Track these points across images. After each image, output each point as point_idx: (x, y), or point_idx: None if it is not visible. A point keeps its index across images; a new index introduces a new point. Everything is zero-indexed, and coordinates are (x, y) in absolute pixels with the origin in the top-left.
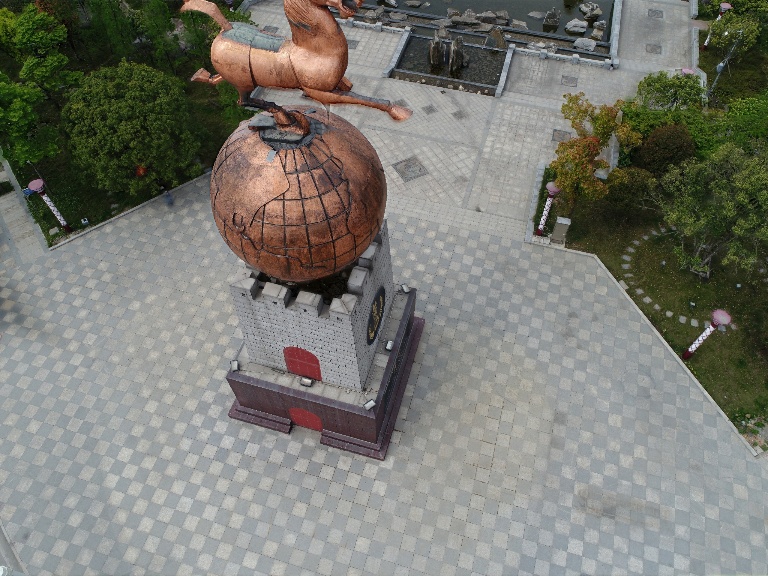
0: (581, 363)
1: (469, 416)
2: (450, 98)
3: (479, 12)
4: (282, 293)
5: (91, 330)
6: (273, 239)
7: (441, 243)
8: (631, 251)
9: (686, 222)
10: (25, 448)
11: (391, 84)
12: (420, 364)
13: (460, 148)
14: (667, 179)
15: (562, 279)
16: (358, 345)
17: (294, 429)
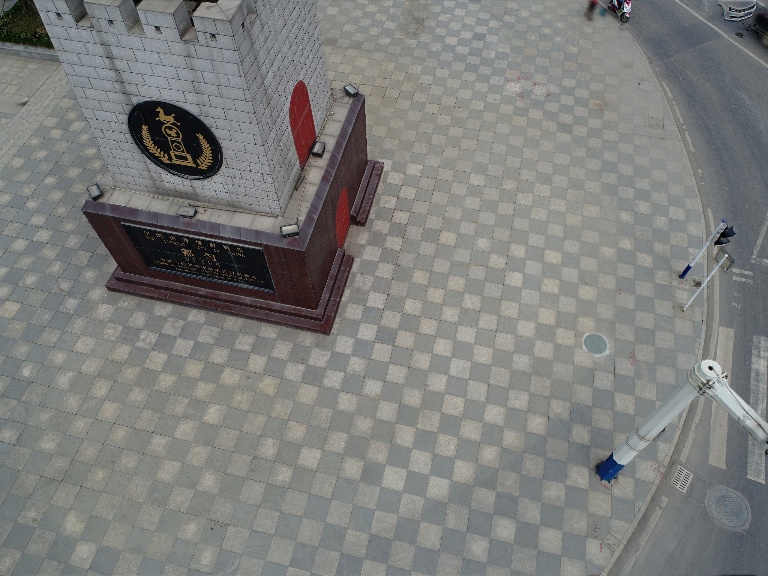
0: None
1: None
2: None
3: None
4: None
5: None
6: None
7: (75, 124)
8: None
9: None
10: None
11: None
12: None
13: None
14: None
15: None
16: None
17: None
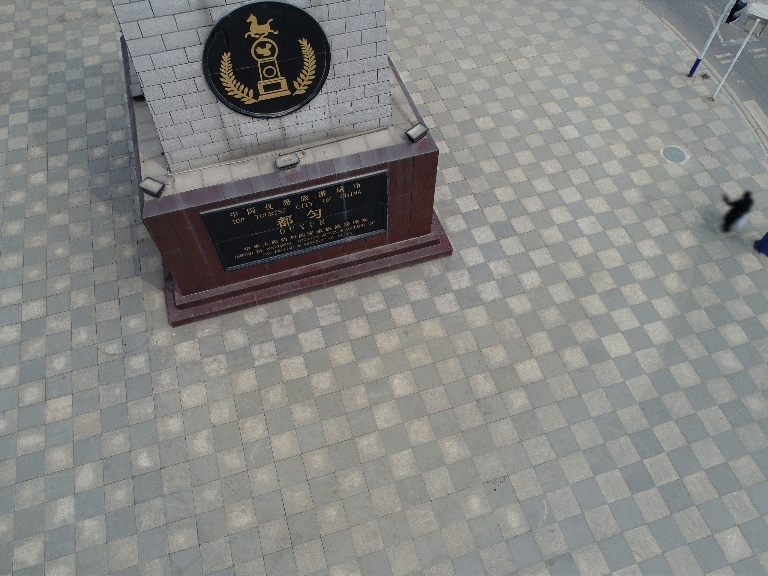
0: None
1: None
2: None
3: None
4: None
5: None
6: None
7: None
8: None
9: None
10: (767, 518)
11: None
12: None
13: None
14: None
15: (0, 41)
16: None
17: None
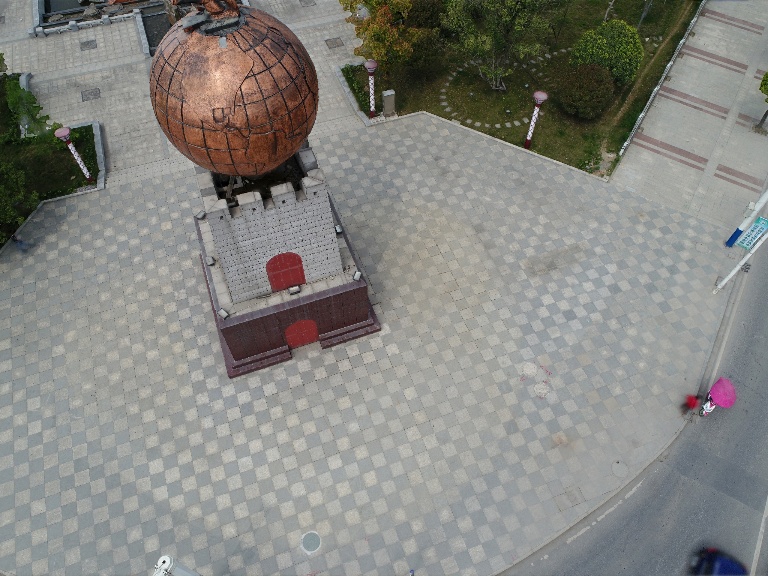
0: (466, 186)
1: (418, 264)
2: None
3: None
4: (257, 196)
5: (28, 396)
6: (258, 117)
7: None
8: (444, 98)
9: None
10: (45, 529)
11: None
12: (355, 251)
13: None
14: (446, 22)
15: (412, 139)
16: None
17: (293, 353)
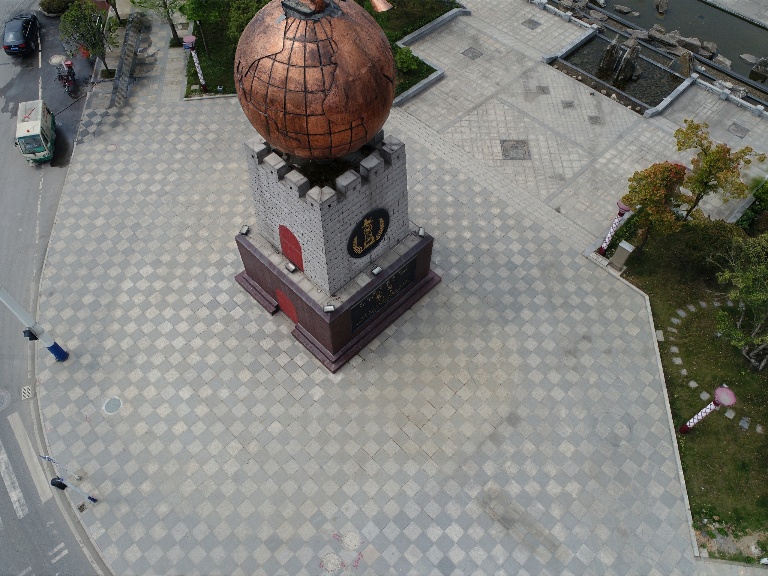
0: (567, 383)
1: (430, 376)
2: (596, 101)
3: (686, 37)
4: (279, 165)
5: (177, 170)
6: (258, 94)
7: (500, 222)
8: (691, 309)
9: (737, 285)
10: (86, 233)
11: (545, 70)
12: (414, 313)
13: (576, 149)
14: (752, 242)
15: (598, 302)
16: (330, 244)
17: (278, 313)
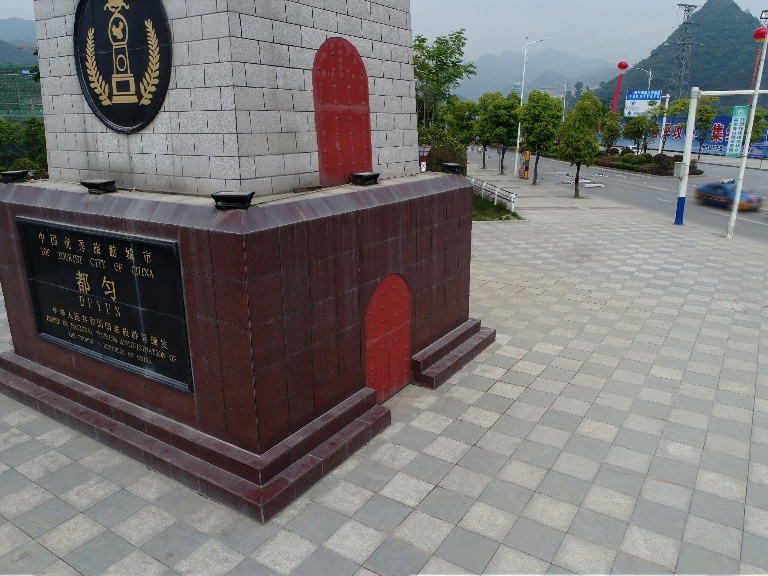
0: None
1: None
2: None
3: None
4: None
5: None
6: None
7: None
8: None
9: None
10: None
11: None
12: None
13: None
14: None
15: None
16: None
17: None
